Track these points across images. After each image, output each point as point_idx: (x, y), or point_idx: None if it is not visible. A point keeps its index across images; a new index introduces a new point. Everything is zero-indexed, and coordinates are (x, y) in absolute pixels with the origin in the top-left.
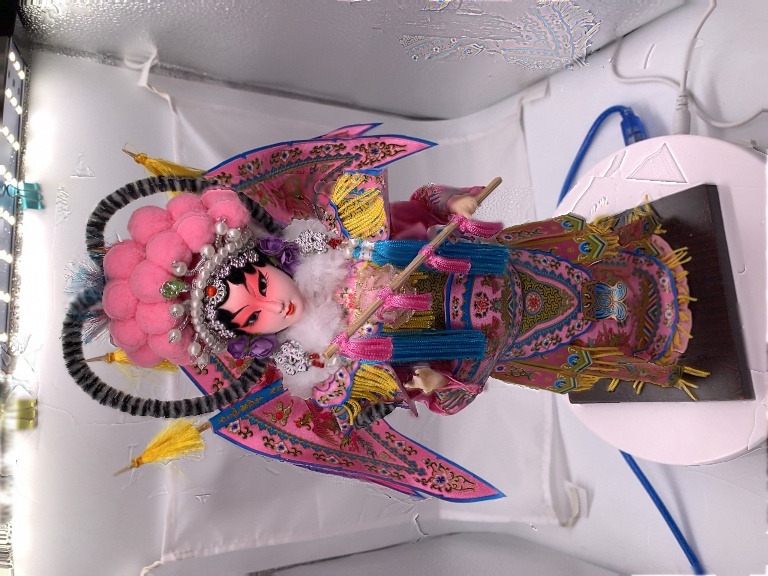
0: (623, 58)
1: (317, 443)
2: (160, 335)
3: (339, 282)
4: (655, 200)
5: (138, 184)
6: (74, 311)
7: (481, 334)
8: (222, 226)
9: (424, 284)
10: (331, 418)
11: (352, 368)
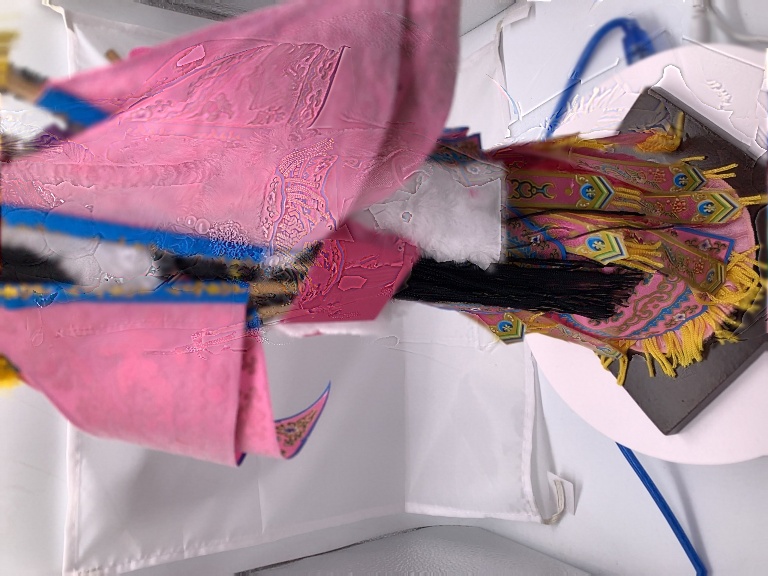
0: None
1: None
2: None
3: None
4: None
5: (7, 172)
6: None
7: None
8: None
9: None
10: None
11: None
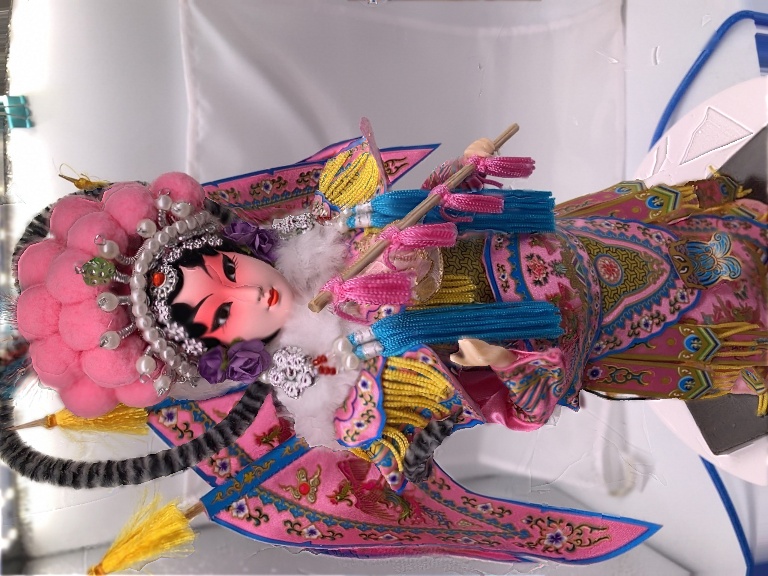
0: (628, 61)
1: (364, 521)
2: (94, 349)
3: (337, 262)
4: (722, 165)
5: None
6: (1, 367)
7: (548, 304)
8: (164, 199)
9: (452, 252)
10: (380, 487)
11: (376, 368)
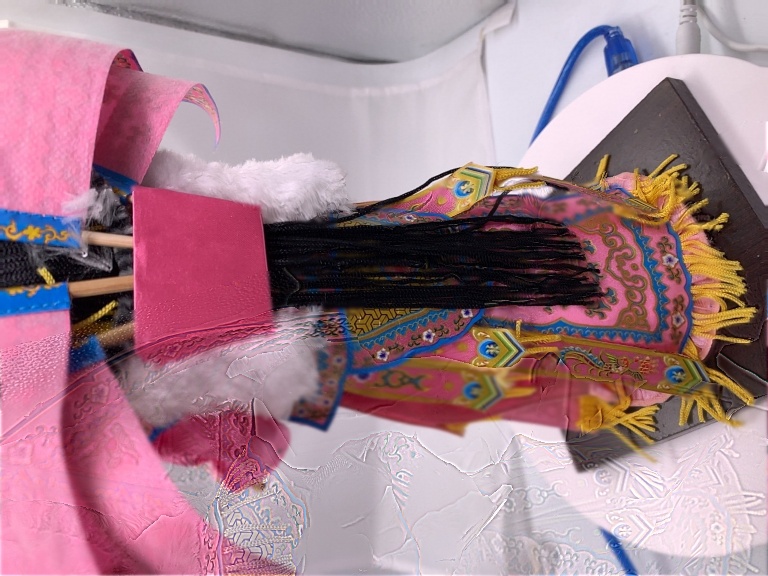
0: (735, 150)
1: None
2: None
3: None
4: None
5: None
6: None
7: None
8: None
9: None
10: None
11: None
